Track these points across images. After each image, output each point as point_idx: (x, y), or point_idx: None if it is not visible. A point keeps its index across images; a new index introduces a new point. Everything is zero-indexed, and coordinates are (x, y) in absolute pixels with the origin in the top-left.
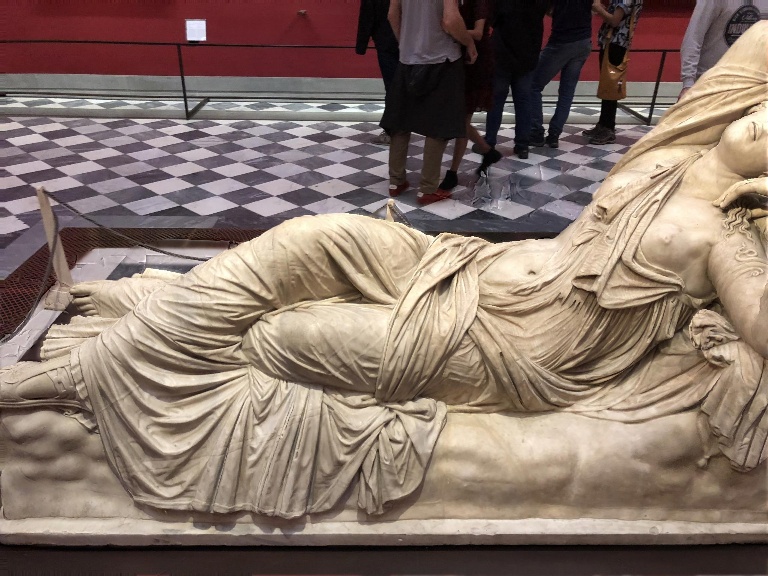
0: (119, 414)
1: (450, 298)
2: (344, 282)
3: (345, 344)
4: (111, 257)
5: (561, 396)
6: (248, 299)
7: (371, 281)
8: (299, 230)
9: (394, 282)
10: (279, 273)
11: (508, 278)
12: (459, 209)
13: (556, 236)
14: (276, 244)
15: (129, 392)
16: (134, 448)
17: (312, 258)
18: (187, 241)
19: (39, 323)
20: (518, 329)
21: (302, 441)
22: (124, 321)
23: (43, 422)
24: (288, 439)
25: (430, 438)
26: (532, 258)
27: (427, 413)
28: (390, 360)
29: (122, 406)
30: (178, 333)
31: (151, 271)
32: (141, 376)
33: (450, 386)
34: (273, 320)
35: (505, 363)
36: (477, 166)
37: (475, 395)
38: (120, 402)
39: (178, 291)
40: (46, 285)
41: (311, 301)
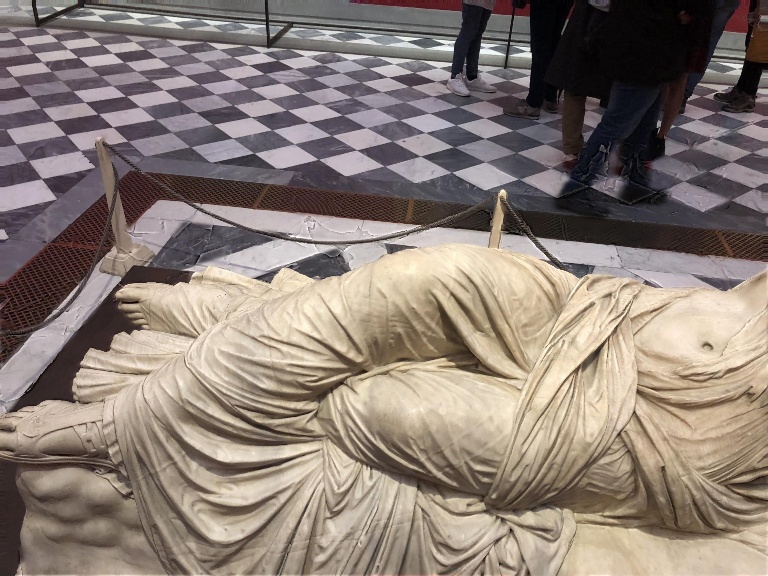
0: (159, 487)
1: (600, 382)
2: (457, 342)
3: (455, 440)
4: (174, 222)
5: (731, 521)
6: (331, 360)
7: (492, 341)
8: (406, 274)
9: (522, 345)
10: (375, 329)
11: (675, 351)
12: (567, 185)
13: (739, 289)
14: (374, 290)
15: (173, 462)
16: (175, 525)
17: (420, 313)
18: (259, 212)
19: (93, 289)
20: (684, 426)
21: (385, 554)
22: (172, 370)
23: (68, 482)
24: (368, 548)
25: (552, 566)
26: (710, 325)
27: (552, 532)
28: (514, 468)
29: (163, 479)
30: (238, 396)
31: (214, 270)
32: (188, 445)
33: (584, 496)
34: (361, 388)
35: (667, 480)
36: (597, 139)
37: (614, 506)
38: (161, 474)
39: (242, 340)
40: (102, 251)
41: (411, 362)
